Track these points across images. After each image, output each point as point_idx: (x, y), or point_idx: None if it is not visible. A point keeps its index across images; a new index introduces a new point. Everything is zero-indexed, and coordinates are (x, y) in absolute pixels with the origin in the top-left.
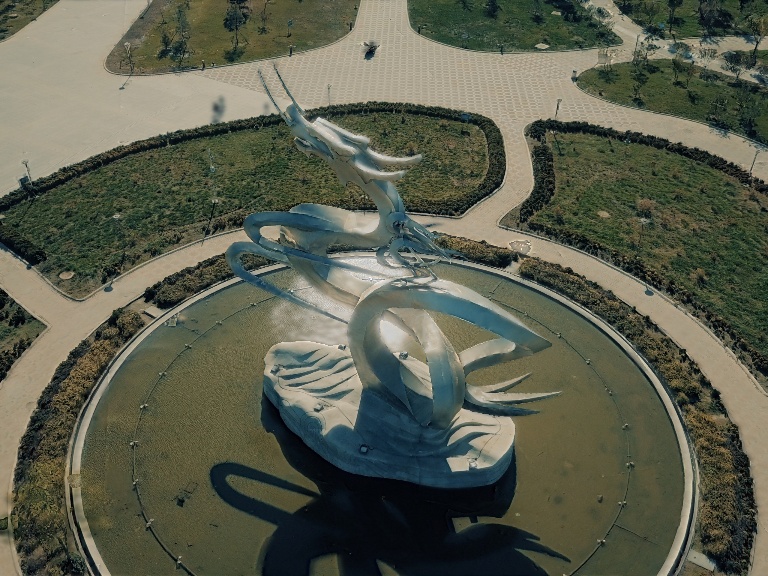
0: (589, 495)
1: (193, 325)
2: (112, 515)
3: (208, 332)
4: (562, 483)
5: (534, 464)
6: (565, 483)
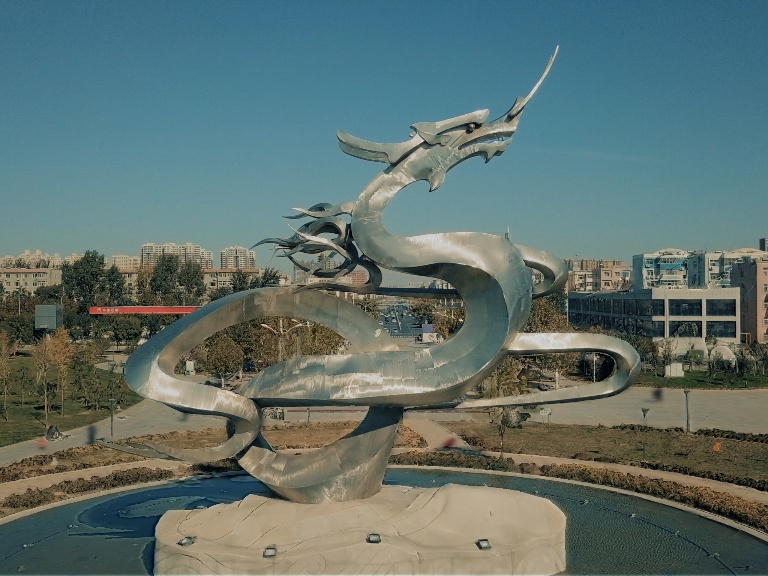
0: (38, 569)
1: (766, 572)
2: (522, 485)
3: (730, 572)
4: (77, 571)
5: (120, 574)
6: (73, 571)
